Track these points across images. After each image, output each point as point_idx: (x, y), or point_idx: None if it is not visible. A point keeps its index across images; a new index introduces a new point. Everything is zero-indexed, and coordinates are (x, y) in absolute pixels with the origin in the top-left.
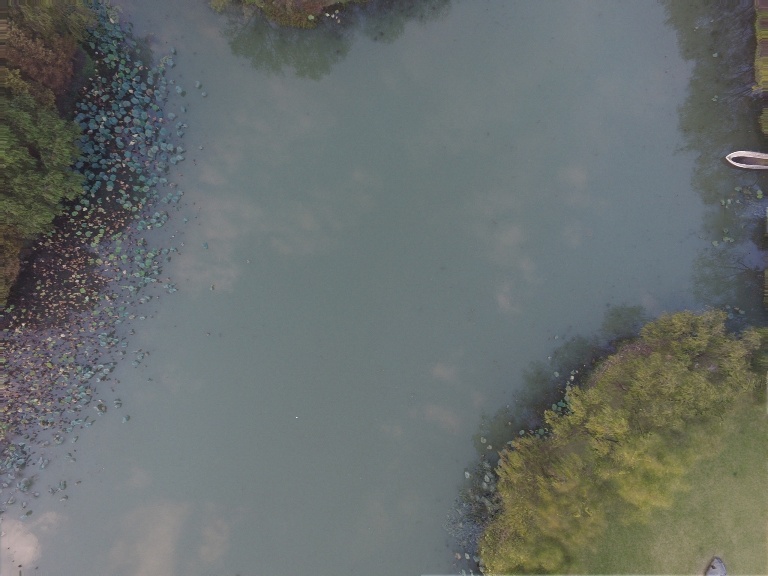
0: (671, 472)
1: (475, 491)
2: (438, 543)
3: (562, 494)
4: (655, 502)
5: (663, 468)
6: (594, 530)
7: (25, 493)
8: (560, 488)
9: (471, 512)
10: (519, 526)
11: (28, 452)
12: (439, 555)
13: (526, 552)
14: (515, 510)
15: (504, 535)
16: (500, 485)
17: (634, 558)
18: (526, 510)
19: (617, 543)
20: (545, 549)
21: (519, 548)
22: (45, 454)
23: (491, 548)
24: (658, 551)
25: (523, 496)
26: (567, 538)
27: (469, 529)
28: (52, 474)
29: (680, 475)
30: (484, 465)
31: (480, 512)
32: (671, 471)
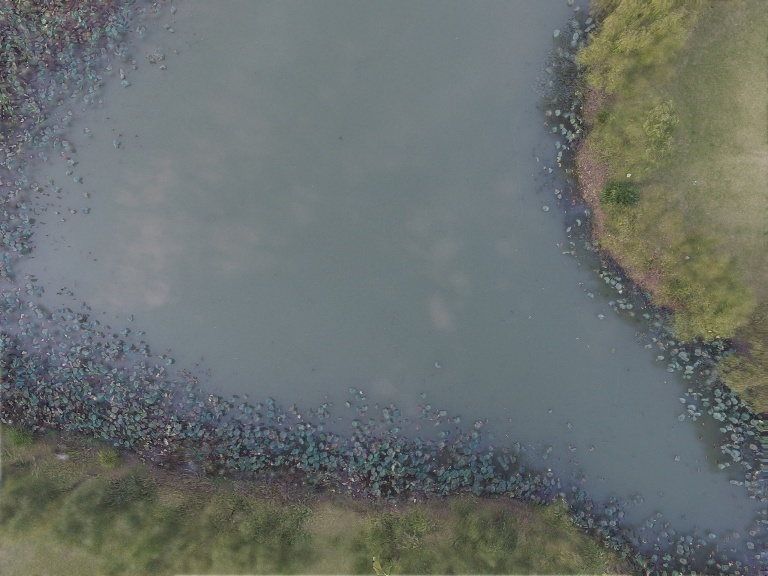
0: (755, 22)
1: (564, 49)
2: (528, 104)
3: (649, 52)
4: (740, 51)
5: (747, 19)
6: (681, 82)
7: (123, 60)
8: (647, 46)
9: (561, 71)
10: (608, 83)
11: (126, 17)
12: (529, 116)
13: (615, 109)
14: (603, 68)
15: (593, 94)
16: (589, 40)
17: (722, 106)
18: (614, 68)
19: (704, 93)
20: (633, 105)
21: (608, 105)
22: (142, 22)
23: (581, 102)
24: (745, 98)
25: (611, 54)
26: (655, 93)
27: (559, 89)
28: (149, 41)
29: (764, 25)
30: (572, 24)
31: (569, 71)
32: (755, 21)
